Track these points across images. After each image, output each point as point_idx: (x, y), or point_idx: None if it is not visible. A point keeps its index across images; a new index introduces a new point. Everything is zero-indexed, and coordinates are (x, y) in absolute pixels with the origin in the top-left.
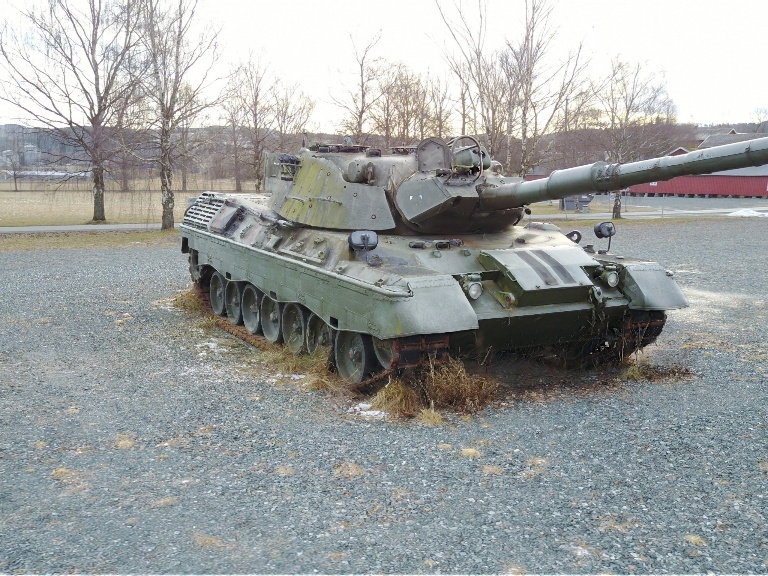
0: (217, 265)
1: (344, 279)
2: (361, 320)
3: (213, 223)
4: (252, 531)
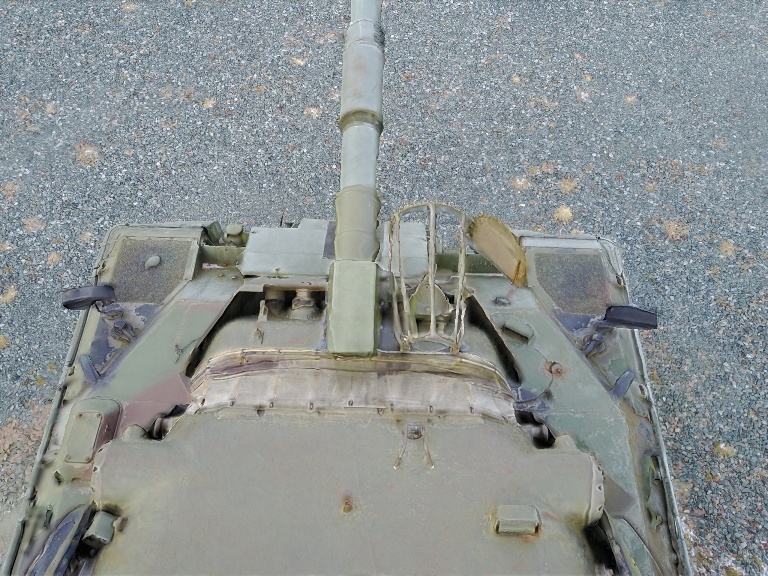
0: None
1: None
2: None
3: None
4: (766, 184)
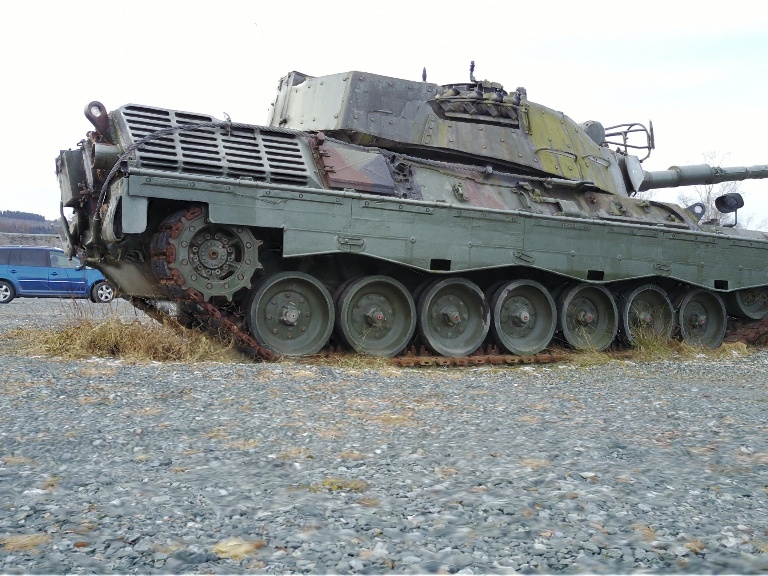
0: (391, 250)
1: (743, 238)
2: (762, 274)
3: (340, 173)
4: None
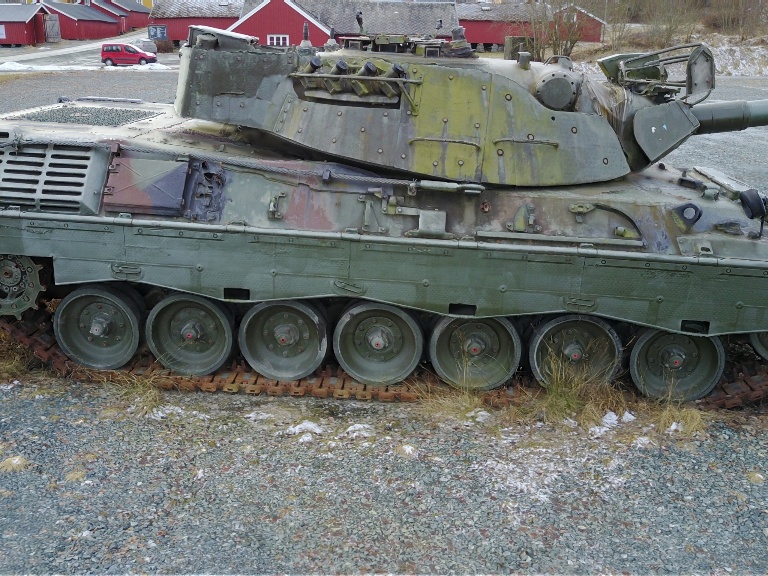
0: (173, 278)
1: (748, 265)
2: None
3: (116, 196)
4: None
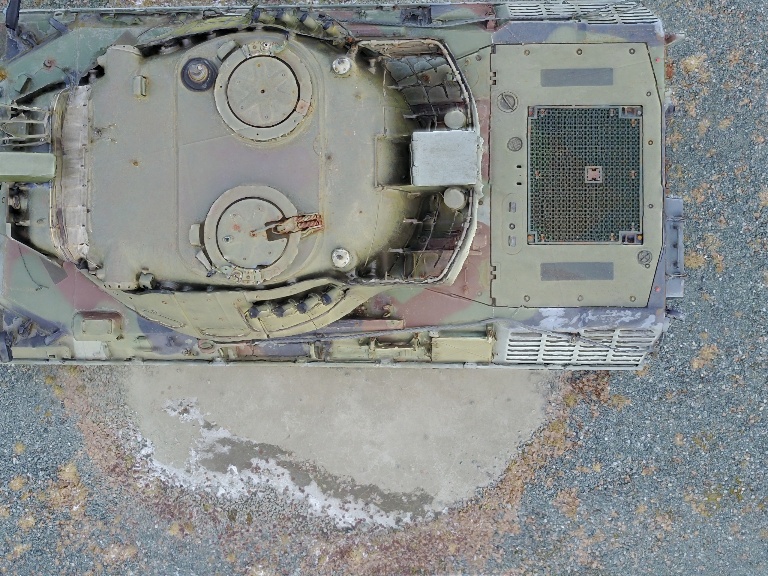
0: None
1: None
2: None
3: (481, 4)
4: None
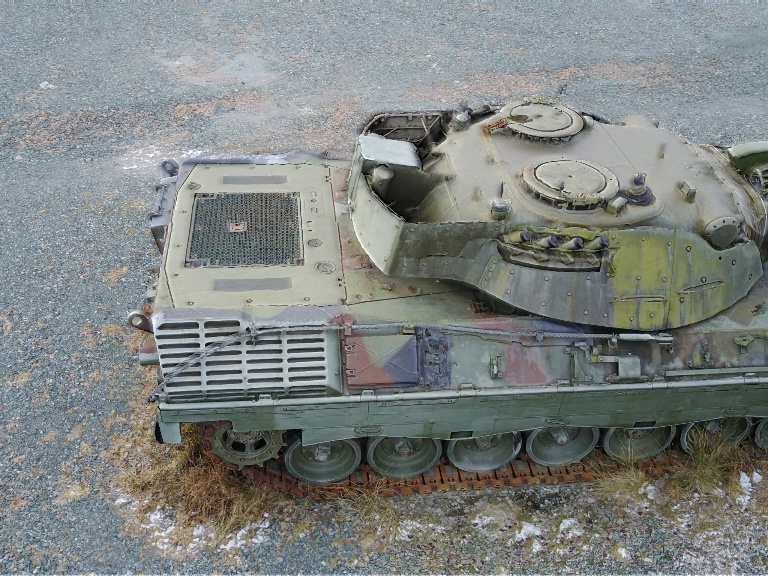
0: (408, 432)
1: None
2: None
3: (359, 379)
4: None
